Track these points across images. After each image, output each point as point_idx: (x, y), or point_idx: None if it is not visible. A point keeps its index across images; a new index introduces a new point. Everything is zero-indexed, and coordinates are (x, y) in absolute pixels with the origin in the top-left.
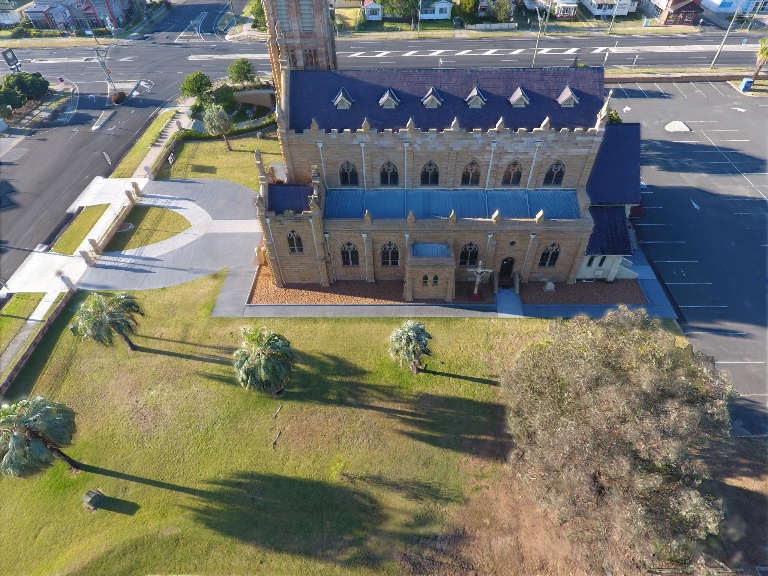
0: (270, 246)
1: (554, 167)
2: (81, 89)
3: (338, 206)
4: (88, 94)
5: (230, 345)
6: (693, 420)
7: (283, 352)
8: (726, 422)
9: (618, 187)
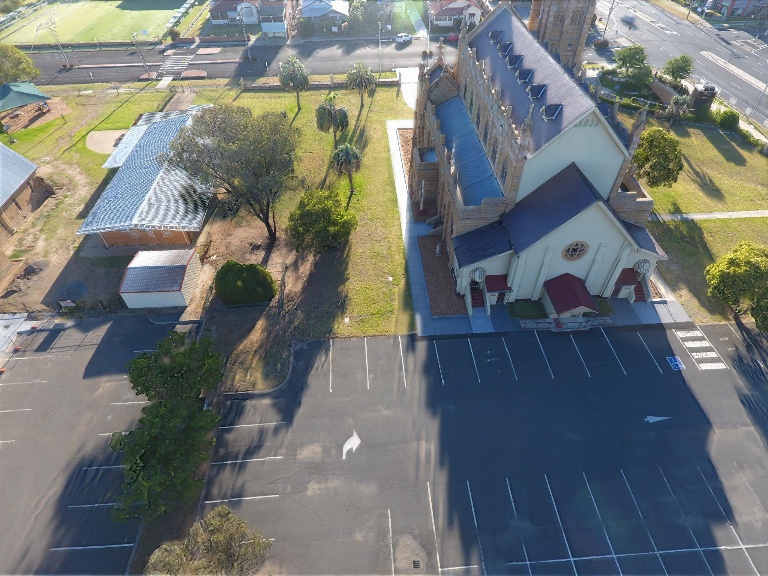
0: (416, 101)
1: (505, 163)
2: (606, 32)
3: (449, 106)
4: (601, 36)
5: (366, 129)
6: (202, 118)
7: (334, 116)
8: (208, 144)
9: (525, 229)
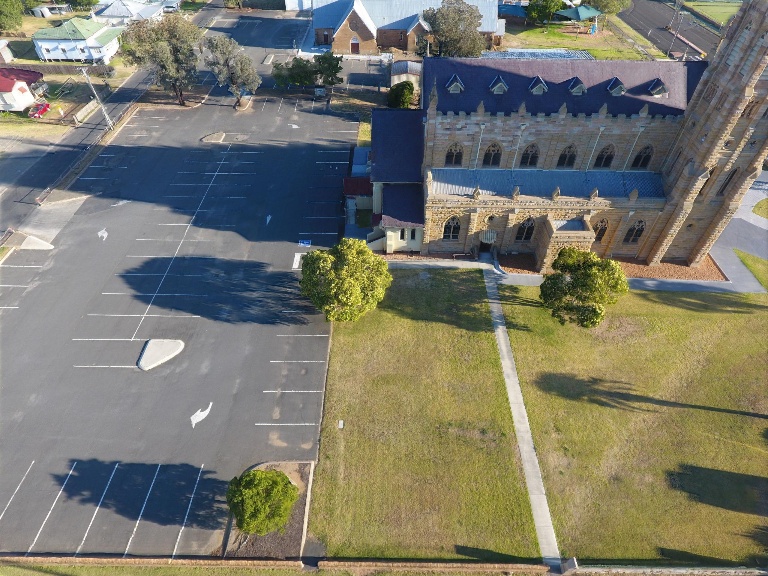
0: None
1: None
2: None
3: None
4: None
5: None
6: None
7: None
8: None
9: None
